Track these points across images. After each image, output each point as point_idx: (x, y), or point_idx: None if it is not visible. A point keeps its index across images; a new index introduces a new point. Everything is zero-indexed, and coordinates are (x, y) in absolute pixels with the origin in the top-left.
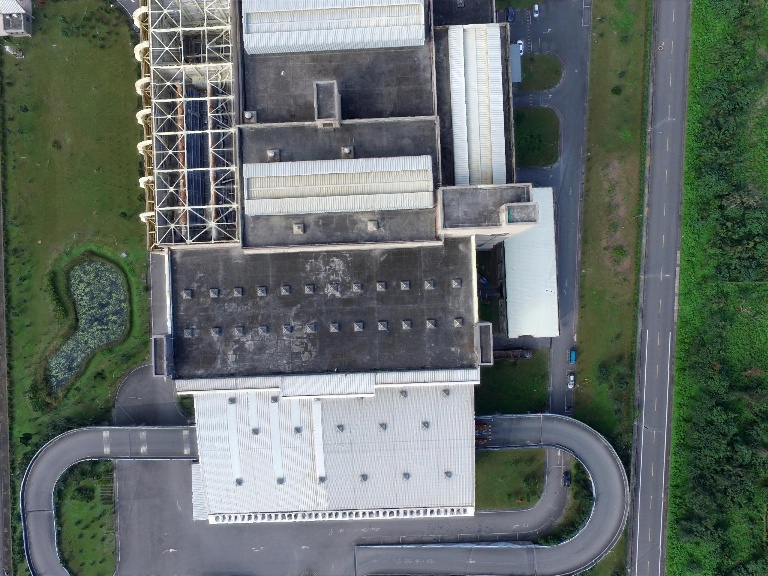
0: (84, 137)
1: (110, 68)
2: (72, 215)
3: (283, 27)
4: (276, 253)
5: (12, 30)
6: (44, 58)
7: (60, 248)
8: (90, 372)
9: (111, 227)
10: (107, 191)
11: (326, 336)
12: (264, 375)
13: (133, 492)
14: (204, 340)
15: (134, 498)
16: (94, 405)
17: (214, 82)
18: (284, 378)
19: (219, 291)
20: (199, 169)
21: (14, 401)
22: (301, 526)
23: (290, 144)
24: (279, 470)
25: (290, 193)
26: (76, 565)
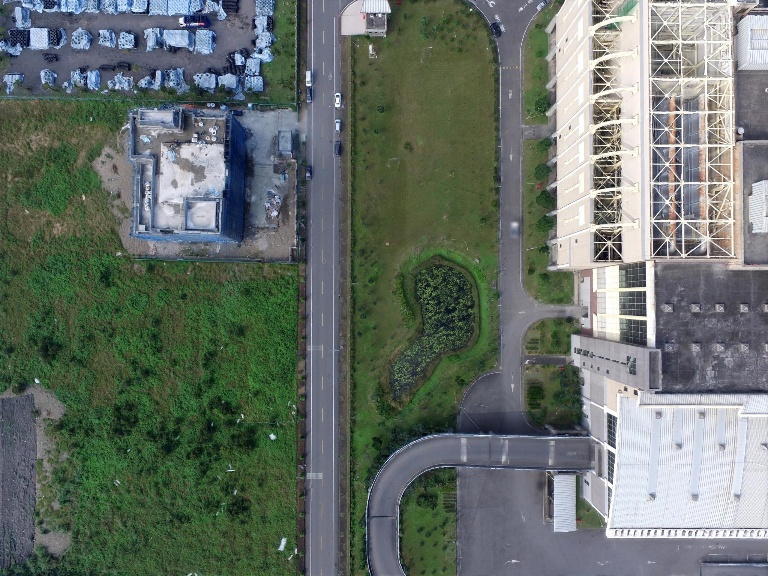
0: (437, 140)
1: (466, 72)
2: (422, 218)
3: None
4: (760, 270)
5: (374, 30)
6: (398, 59)
7: (409, 251)
8: (436, 378)
9: (462, 232)
10: (459, 196)
11: None
12: (746, 392)
13: (476, 501)
14: (683, 355)
15: (477, 507)
16: (439, 411)
17: (713, 96)
18: (750, 396)
19: (700, 306)
20: (695, 183)
21: (355, 404)
22: (647, 541)
23: None
24: (695, 486)
25: None
26: (416, 573)
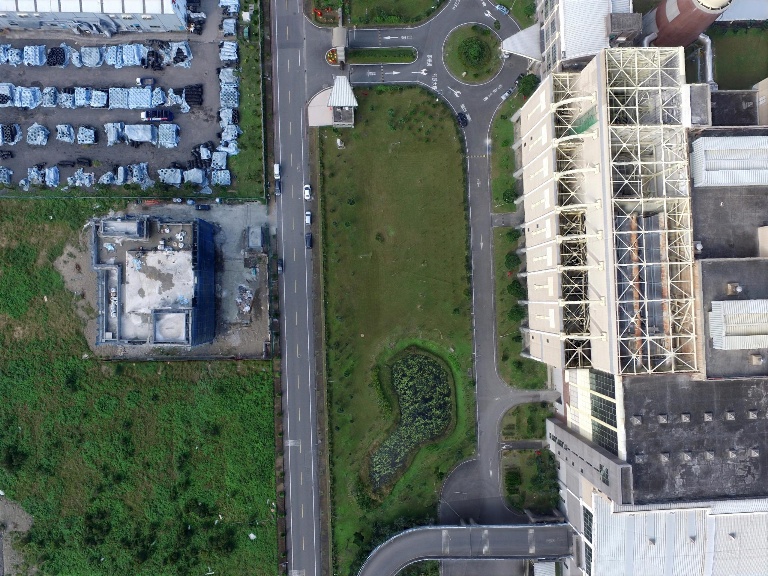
0: (408, 230)
1: (435, 162)
2: (396, 308)
3: (737, 164)
4: None
5: (342, 123)
6: (366, 149)
7: (384, 342)
8: (415, 468)
9: (436, 321)
10: (432, 285)
11: (767, 459)
12: (713, 499)
13: None
14: (653, 465)
15: None
16: (419, 501)
17: (672, 215)
18: None
19: (667, 417)
20: (658, 300)
21: (335, 498)
22: None
23: (745, 277)
24: None
25: (763, 329)
26: None
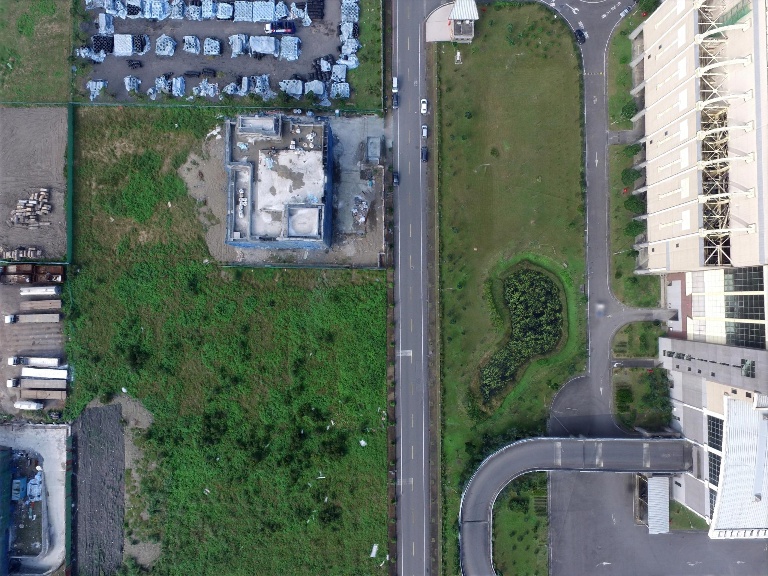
0: (523, 146)
1: (551, 78)
2: (509, 223)
3: None
4: None
5: (462, 36)
6: (483, 65)
7: (497, 256)
8: (525, 382)
9: (549, 237)
10: (545, 201)
11: None
12: None
13: (567, 504)
14: None
15: (568, 510)
16: (529, 415)
17: None
18: None
19: None
20: None
21: (445, 409)
22: (736, 541)
23: None
24: None
25: None
26: None
